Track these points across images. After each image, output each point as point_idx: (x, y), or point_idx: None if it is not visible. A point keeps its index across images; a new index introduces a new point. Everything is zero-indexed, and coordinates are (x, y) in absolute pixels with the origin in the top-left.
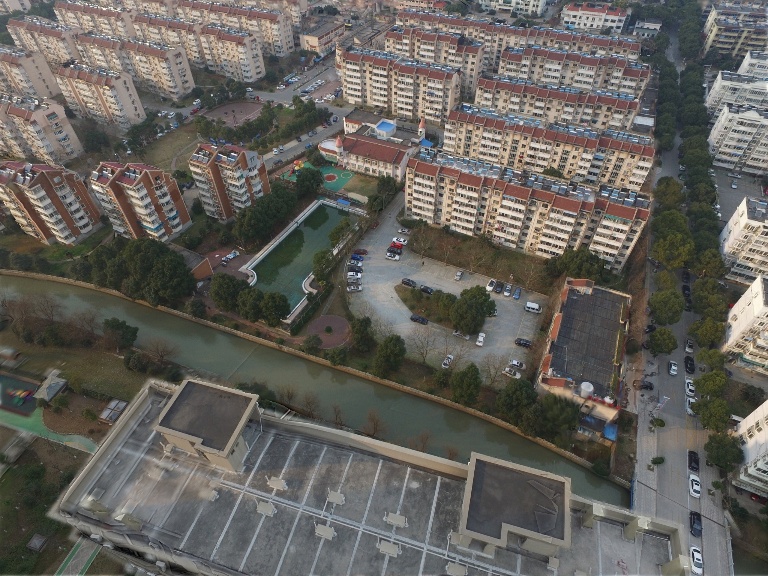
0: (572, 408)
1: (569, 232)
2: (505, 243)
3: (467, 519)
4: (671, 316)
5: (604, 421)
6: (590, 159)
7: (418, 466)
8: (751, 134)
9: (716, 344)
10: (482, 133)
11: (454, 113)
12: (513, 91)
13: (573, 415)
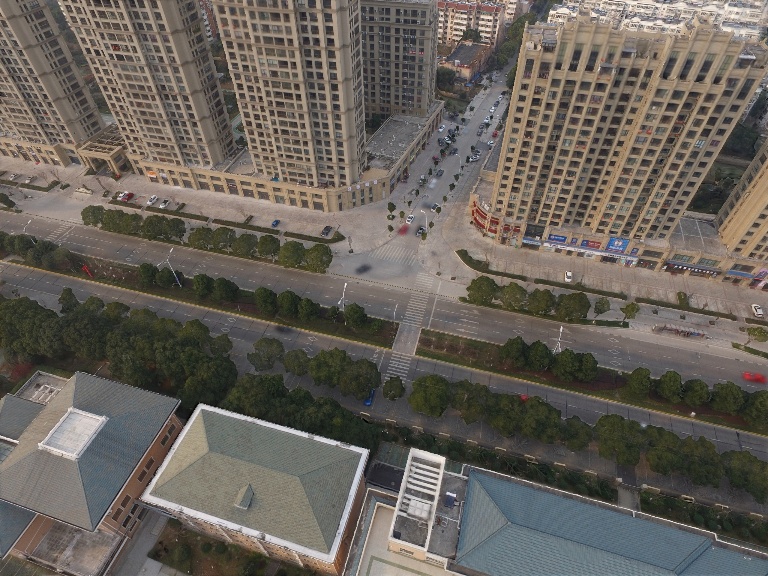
0: None
1: (465, 25)
2: None
3: None
4: (508, 53)
5: (466, 79)
6: (485, 0)
7: None
8: None
9: None
10: None
11: None
12: None
13: (451, 73)
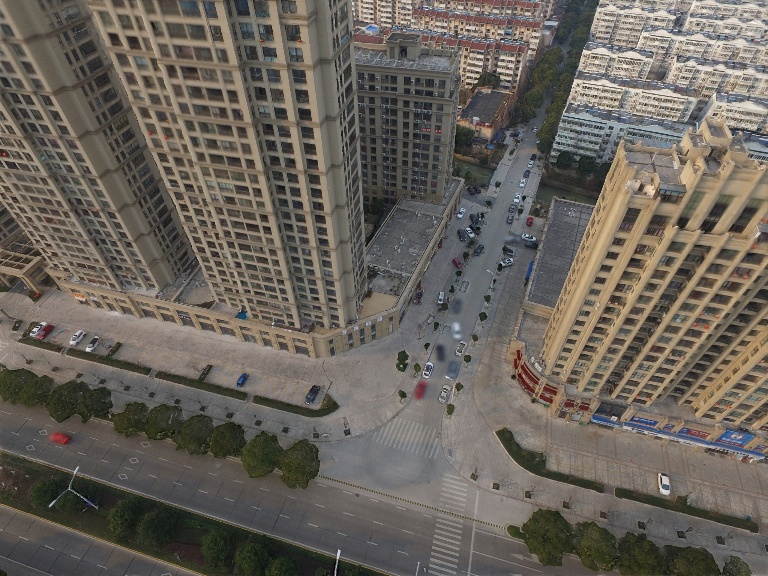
0: (468, 130)
1: (482, 66)
2: None
3: (387, 39)
4: (535, 103)
5: (487, 140)
6: (503, 34)
7: (374, 50)
8: (613, 22)
9: (558, 113)
10: (435, 23)
11: (416, 10)
12: (459, 1)
13: (469, 133)
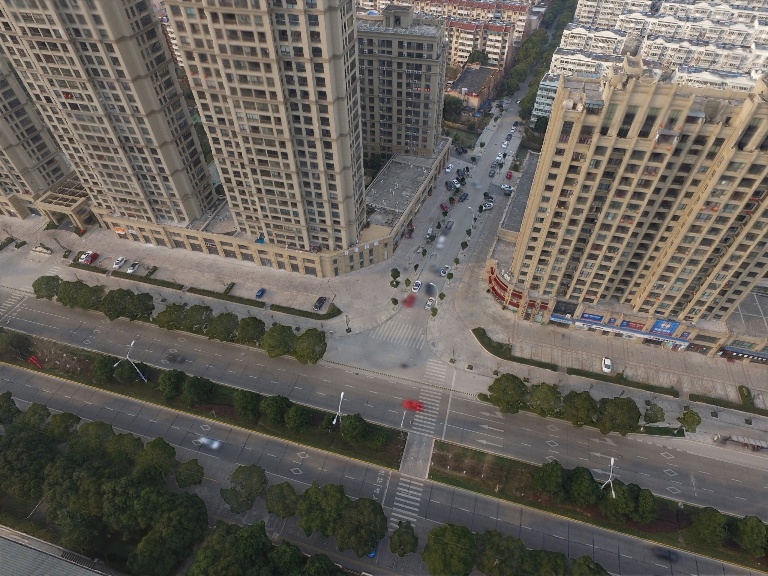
0: None
1: (472, 45)
2: None
3: None
4: (519, 77)
5: (474, 109)
6: (492, 17)
7: (373, 20)
8: (595, 7)
9: None
10: (430, 7)
11: None
12: None
13: (458, 102)
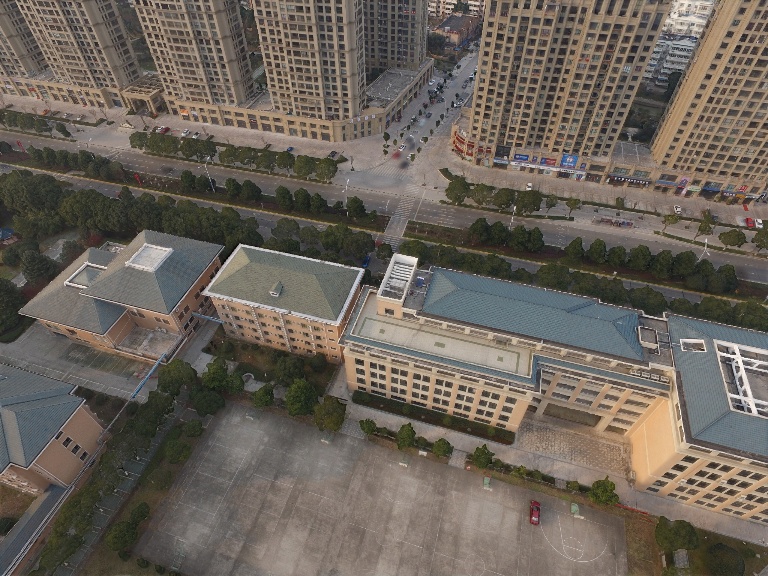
0: None
1: None
2: (431, 14)
3: None
4: None
5: (455, 44)
6: None
7: None
8: None
9: None
10: None
11: None
12: None
13: (442, 38)
